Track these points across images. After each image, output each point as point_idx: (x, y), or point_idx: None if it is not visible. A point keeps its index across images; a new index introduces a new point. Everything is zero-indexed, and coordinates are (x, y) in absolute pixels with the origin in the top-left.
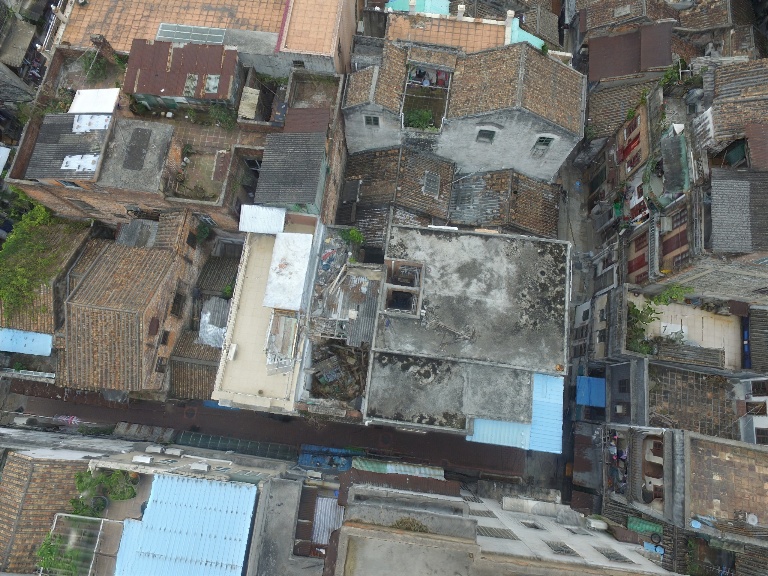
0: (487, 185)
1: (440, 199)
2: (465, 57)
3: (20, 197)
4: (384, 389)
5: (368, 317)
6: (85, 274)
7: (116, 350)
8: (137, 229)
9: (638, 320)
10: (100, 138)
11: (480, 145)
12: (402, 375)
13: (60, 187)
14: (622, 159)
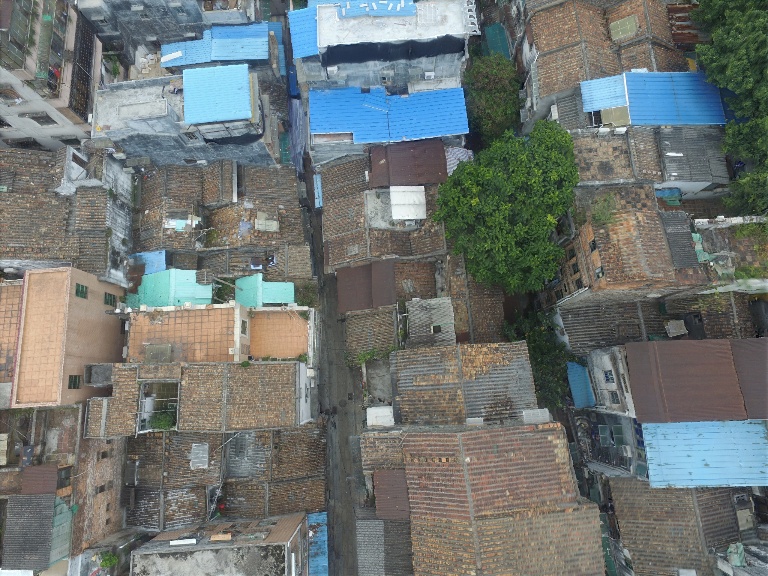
0: (256, 436)
1: (210, 466)
2: (188, 367)
3: None
4: None
5: None
6: None
7: None
8: None
9: None
10: None
11: None
12: None
13: None
14: None
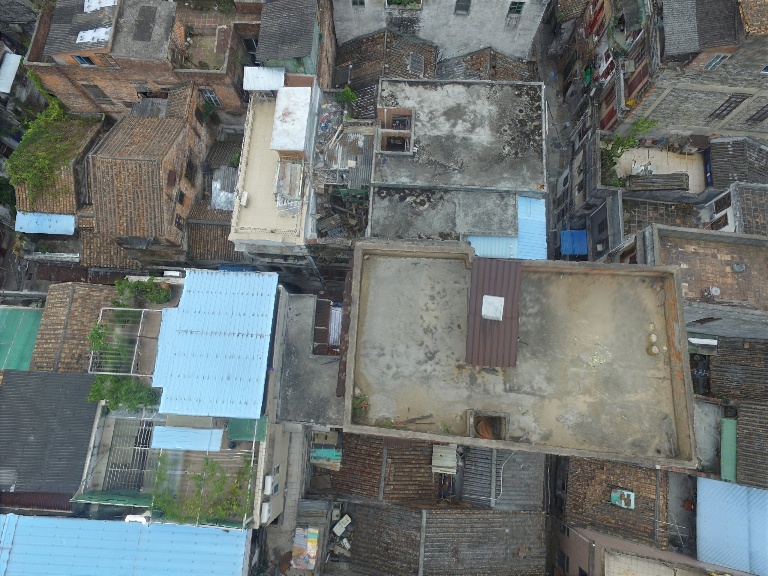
0: (468, 66)
1: (425, 77)
2: None
3: (36, 87)
4: (384, 217)
5: (366, 165)
6: (105, 136)
7: (139, 198)
8: (148, 106)
9: (610, 158)
10: (110, 13)
11: (458, 20)
12: (400, 205)
13: (75, 66)
14: (590, 32)
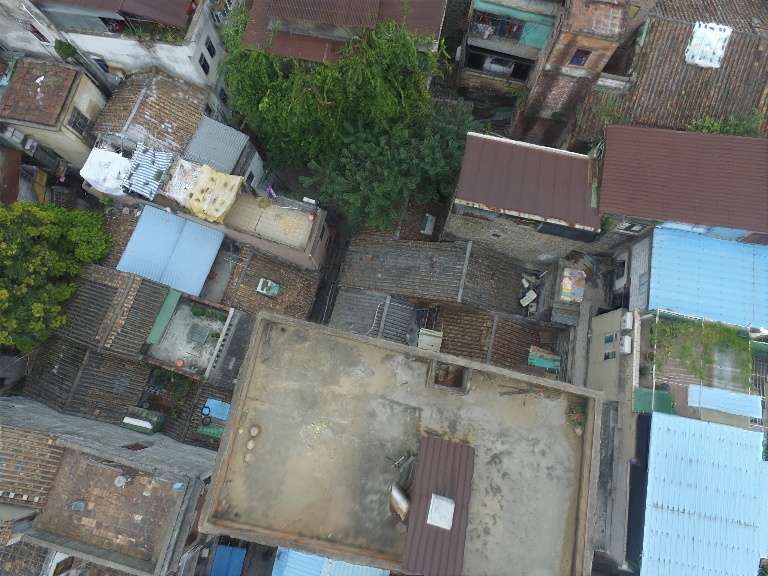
0: None
1: None
2: None
3: None
4: None
5: None
6: None
7: None
8: None
9: None
10: None
11: None
12: None
13: None
14: None
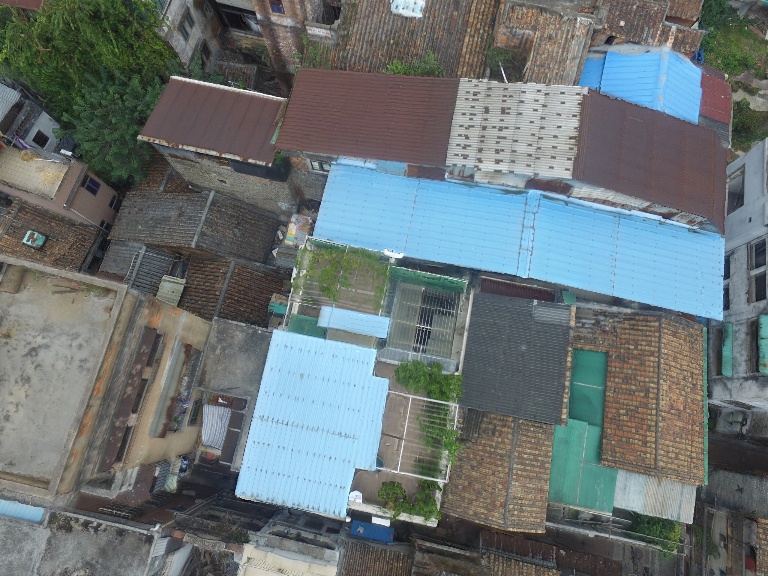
0: None
1: None
2: None
3: None
4: (130, 567)
5: None
6: None
7: None
8: None
9: None
10: None
11: None
12: None
13: None
14: None
